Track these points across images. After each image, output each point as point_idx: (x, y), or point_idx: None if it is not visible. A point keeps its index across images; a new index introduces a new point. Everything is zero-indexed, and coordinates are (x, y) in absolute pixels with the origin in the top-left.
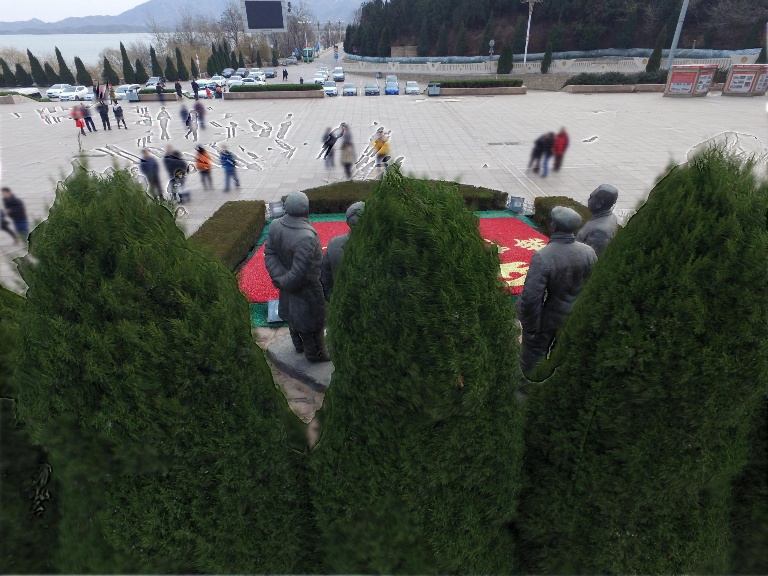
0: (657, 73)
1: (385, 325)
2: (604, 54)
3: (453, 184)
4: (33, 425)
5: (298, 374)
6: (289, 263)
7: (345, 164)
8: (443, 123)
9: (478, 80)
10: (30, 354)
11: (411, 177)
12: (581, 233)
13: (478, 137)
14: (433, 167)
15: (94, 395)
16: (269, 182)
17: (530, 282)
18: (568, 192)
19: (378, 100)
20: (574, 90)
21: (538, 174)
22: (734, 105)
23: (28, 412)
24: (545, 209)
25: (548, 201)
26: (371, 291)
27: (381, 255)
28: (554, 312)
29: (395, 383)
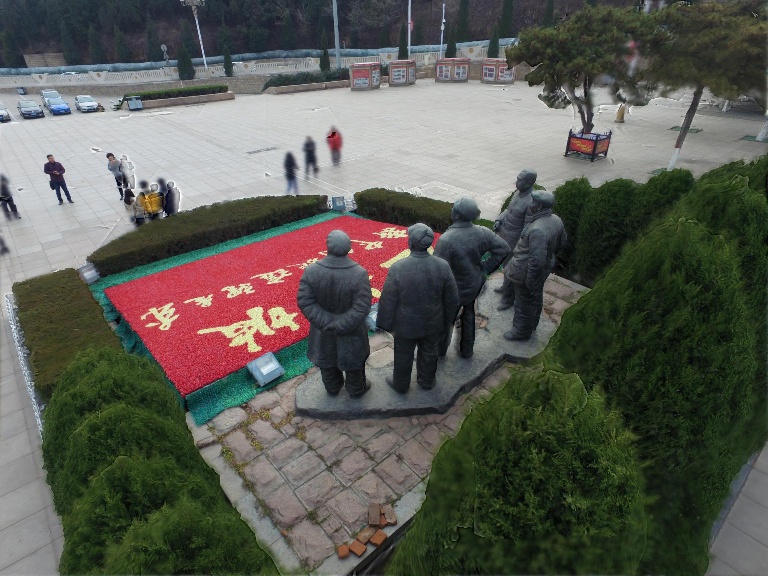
0: (339, 71)
1: (765, 276)
2: (286, 56)
3: (270, 198)
4: (707, 443)
5: (357, 413)
6: (345, 305)
7: (107, 203)
8: (179, 139)
9: (180, 89)
10: (707, 384)
11: (204, 201)
12: (518, 208)
13: (231, 148)
14: (216, 186)
15: (735, 392)
16: (20, 247)
17: (539, 251)
18: (359, 184)
19: (68, 122)
20: (277, 91)
21: (320, 173)
22: (404, 93)
23: (693, 438)
24: (372, 202)
25: (369, 194)
26: (761, 257)
27: (762, 232)
28: (547, 269)
29: (760, 312)
